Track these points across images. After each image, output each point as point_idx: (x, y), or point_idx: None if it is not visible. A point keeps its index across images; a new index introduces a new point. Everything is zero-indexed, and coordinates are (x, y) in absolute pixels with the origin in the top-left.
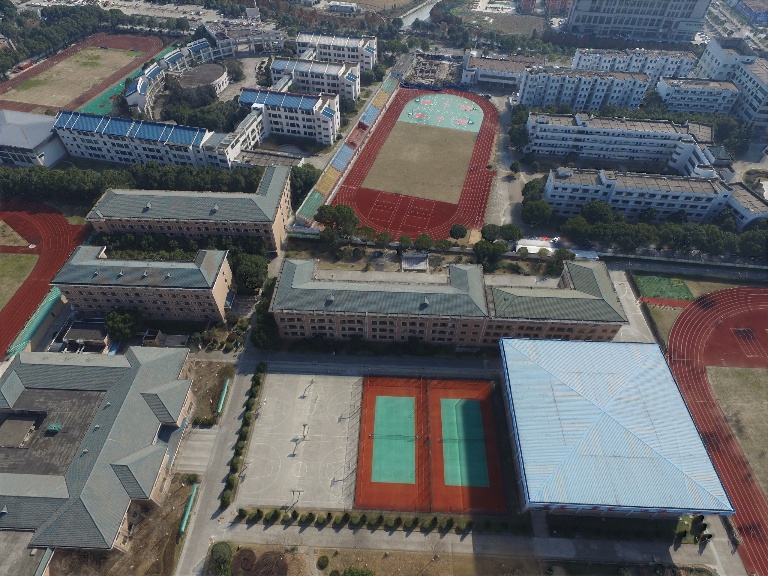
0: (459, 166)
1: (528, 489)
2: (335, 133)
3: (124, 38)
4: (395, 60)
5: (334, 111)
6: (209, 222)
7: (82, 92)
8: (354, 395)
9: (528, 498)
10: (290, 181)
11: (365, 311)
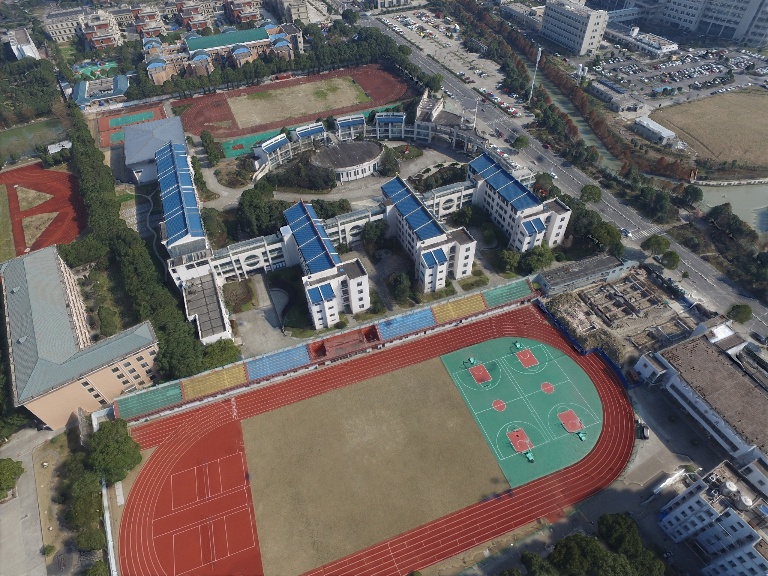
0: (381, 520)
1: None
2: (336, 317)
3: (383, 78)
4: (599, 253)
5: (334, 295)
6: None
7: (272, 120)
8: None
9: None
10: (157, 355)
11: None
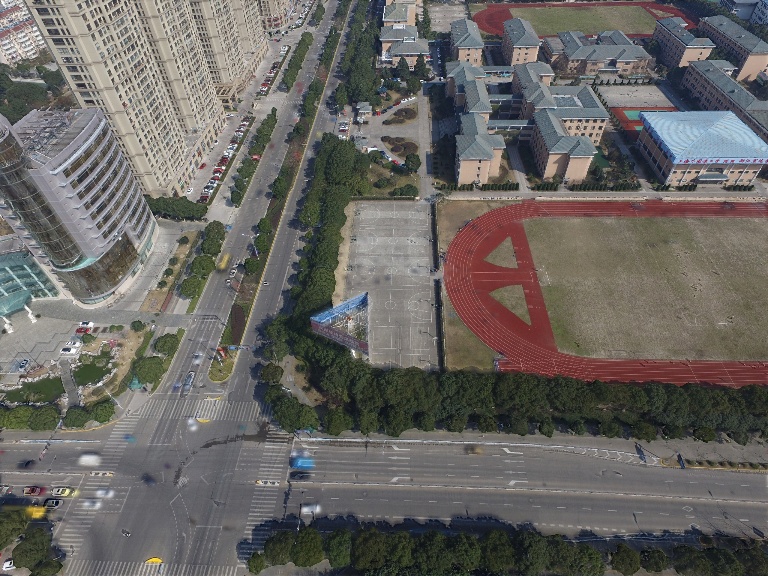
0: None
1: None
2: None
3: None
4: None
5: None
6: (732, 41)
7: None
8: (662, 105)
9: None
10: None
11: (712, 80)
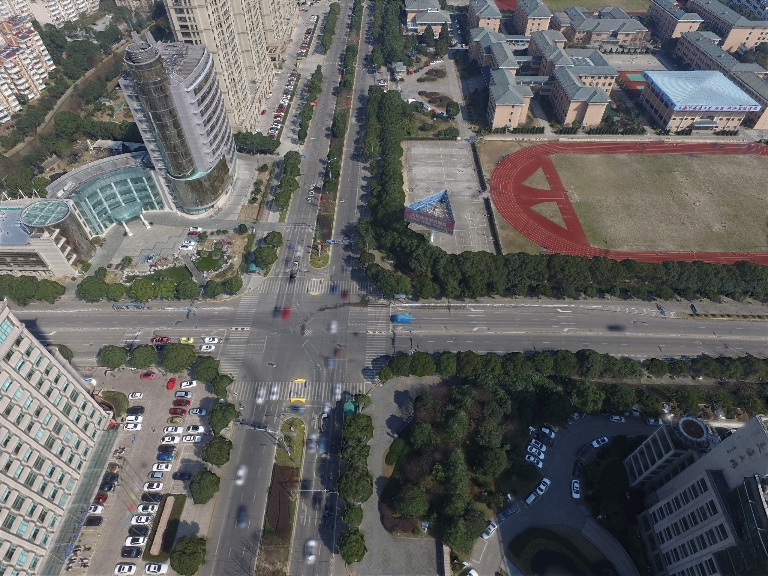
0: None
1: (648, 70)
2: None
3: None
4: None
5: None
6: None
7: None
8: None
9: (645, 70)
10: None
11: None
